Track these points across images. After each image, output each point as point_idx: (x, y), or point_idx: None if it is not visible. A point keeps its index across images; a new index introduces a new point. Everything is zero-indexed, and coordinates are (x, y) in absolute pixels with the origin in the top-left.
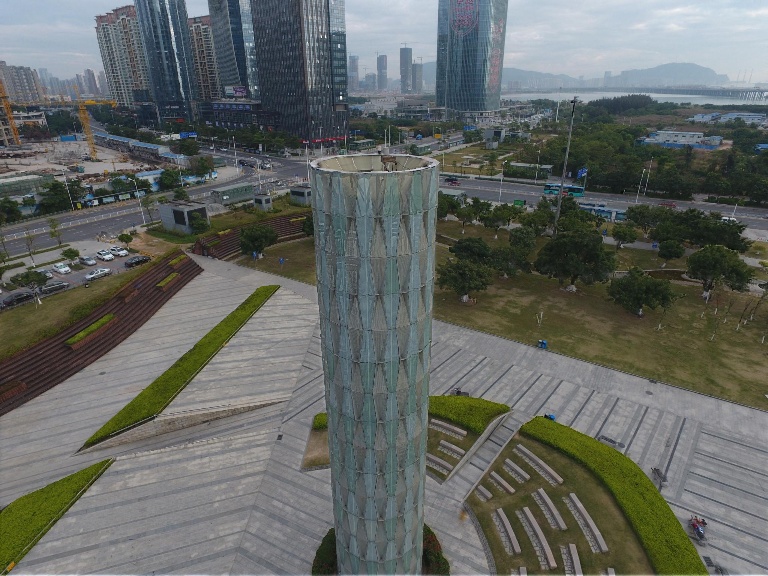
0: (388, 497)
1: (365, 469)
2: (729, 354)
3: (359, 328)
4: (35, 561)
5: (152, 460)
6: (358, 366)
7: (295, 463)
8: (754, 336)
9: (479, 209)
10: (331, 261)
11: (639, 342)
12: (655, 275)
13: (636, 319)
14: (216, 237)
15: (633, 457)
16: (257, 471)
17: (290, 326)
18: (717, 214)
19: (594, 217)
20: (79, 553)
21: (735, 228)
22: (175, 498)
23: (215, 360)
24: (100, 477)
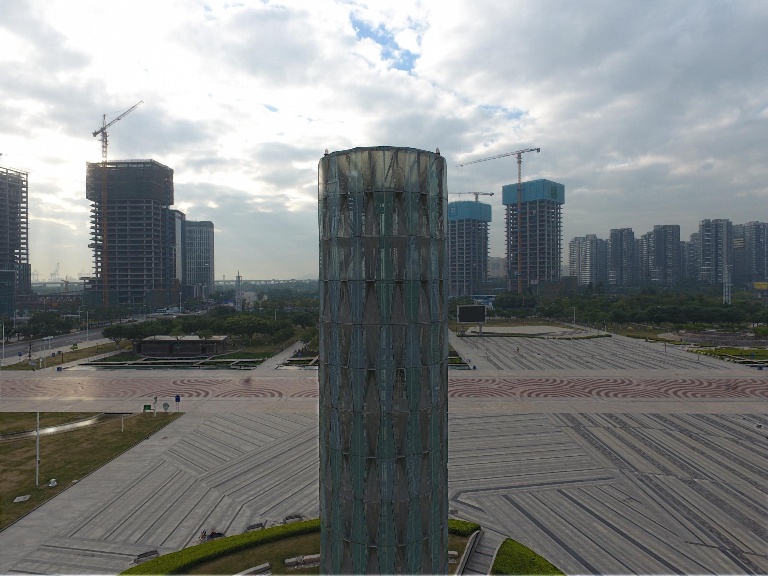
0: None
1: None
2: None
3: None
4: None
5: None
6: None
7: None
8: None
9: None
10: None
11: None
12: None
13: None
14: None
15: None
16: None
17: None
18: None
19: None
20: None
21: None
22: None
23: None
24: None
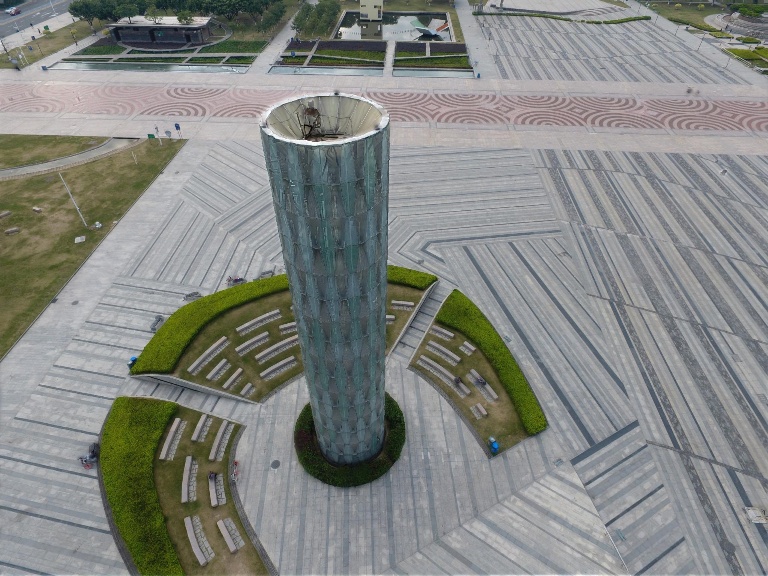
0: None
1: None
2: (4, 254)
3: None
4: None
5: None
6: None
7: None
8: None
9: None
10: None
11: None
12: None
13: None
14: None
15: (172, 310)
16: None
17: None
18: None
19: None
20: None
21: None
22: None
23: None
24: None
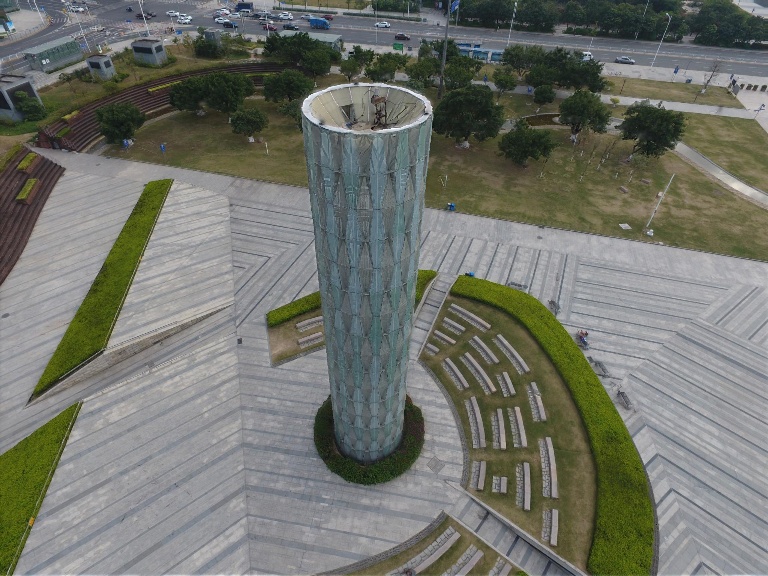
0: (388, 384)
1: (371, 370)
2: (593, 193)
3: (369, 268)
4: (53, 510)
5: (122, 392)
6: (367, 297)
7: (264, 361)
8: (610, 173)
9: (362, 60)
10: (340, 213)
11: (527, 192)
12: (532, 121)
13: (522, 169)
14: (62, 123)
15: (535, 294)
16: (231, 377)
17: (203, 225)
18: (580, 53)
19: (476, 63)
20: (94, 491)
21: (596, 69)
22: (164, 420)
23: (138, 278)
24: (76, 422)
